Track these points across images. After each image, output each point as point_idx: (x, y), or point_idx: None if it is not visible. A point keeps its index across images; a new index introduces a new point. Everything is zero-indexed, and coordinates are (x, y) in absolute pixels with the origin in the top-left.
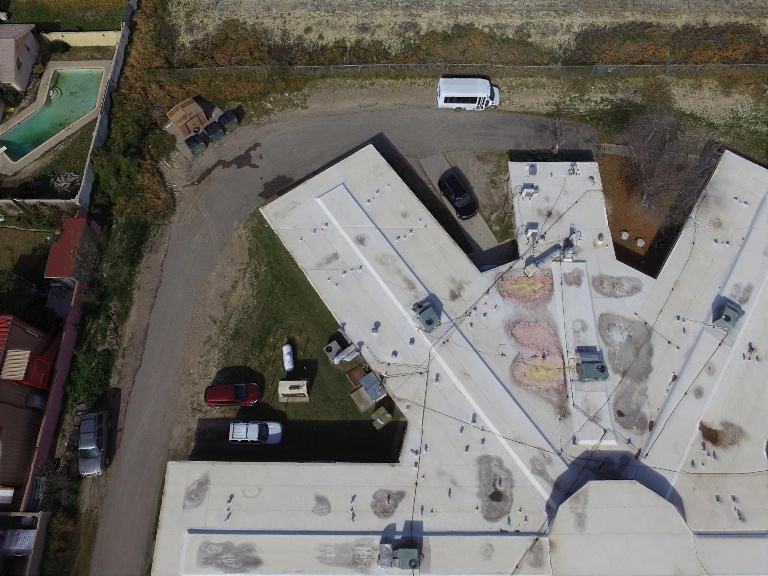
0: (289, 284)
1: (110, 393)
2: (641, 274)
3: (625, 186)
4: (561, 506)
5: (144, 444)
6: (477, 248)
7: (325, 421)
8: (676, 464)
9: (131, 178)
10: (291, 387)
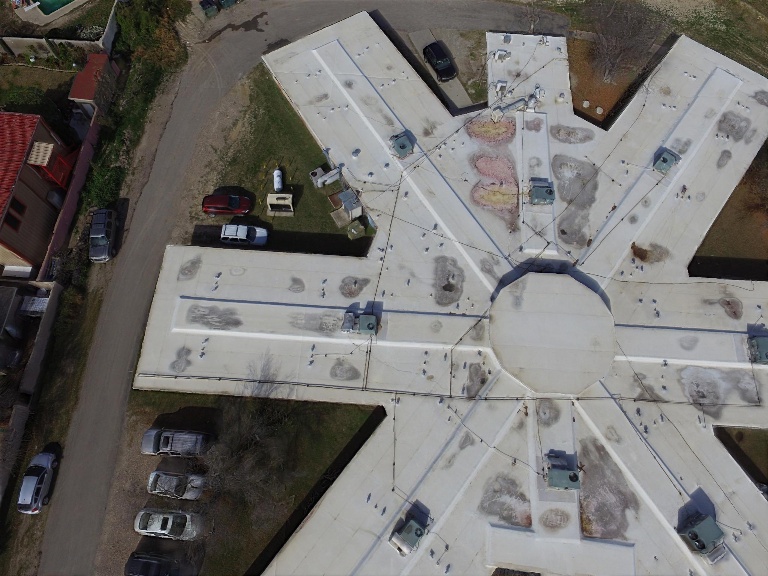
0: (283, 125)
1: (120, 202)
2: (594, 126)
3: (591, 65)
4: (502, 290)
5: (147, 241)
6: (453, 106)
7: (306, 233)
8: (608, 272)
9: (149, 32)
10: (278, 198)
